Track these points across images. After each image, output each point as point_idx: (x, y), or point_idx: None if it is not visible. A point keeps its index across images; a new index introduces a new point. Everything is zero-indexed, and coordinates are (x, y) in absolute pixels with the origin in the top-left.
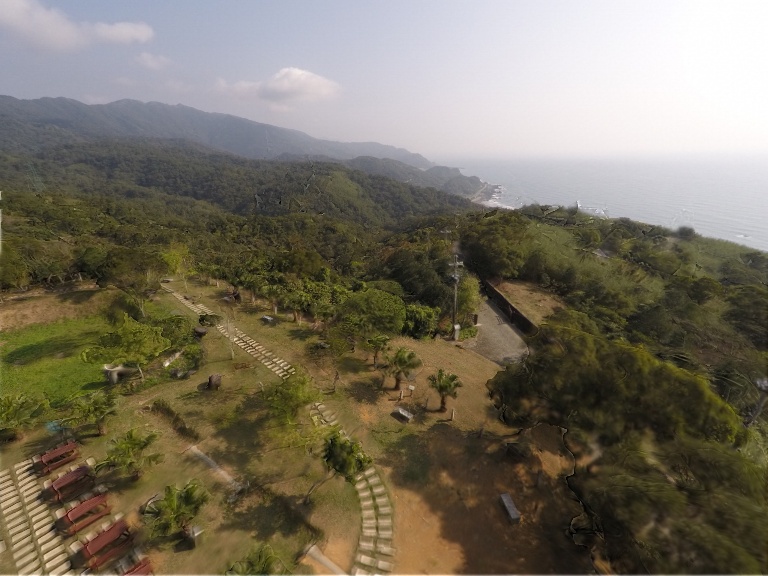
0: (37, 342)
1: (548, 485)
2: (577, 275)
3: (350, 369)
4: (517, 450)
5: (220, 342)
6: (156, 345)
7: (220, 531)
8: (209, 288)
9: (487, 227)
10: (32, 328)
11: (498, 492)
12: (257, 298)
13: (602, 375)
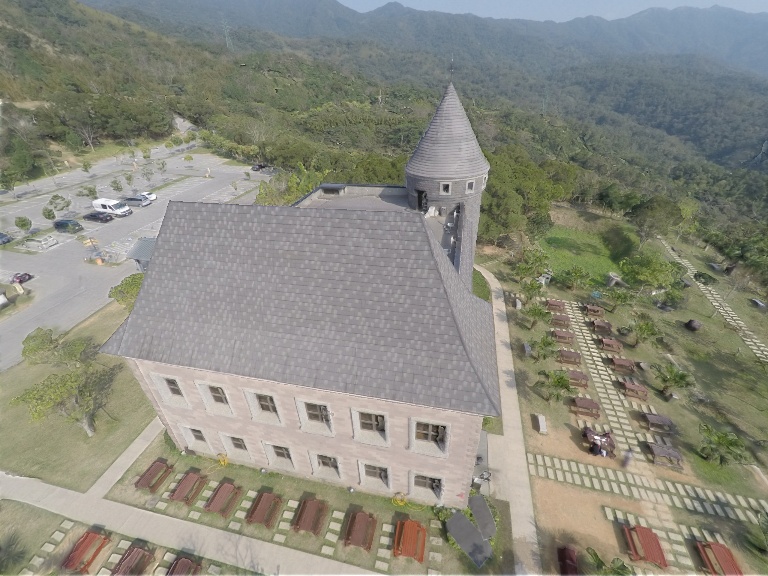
0: (561, 237)
1: None
2: None
3: None
4: None
5: (700, 299)
6: (667, 278)
7: (683, 407)
8: (696, 248)
9: None
10: (559, 227)
11: None
12: (752, 279)
13: None
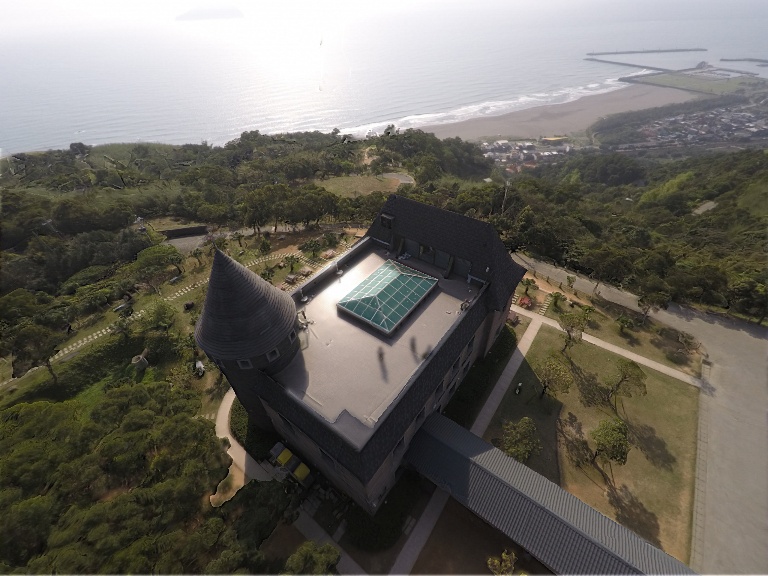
0: None
1: None
2: (154, 200)
3: (200, 270)
4: (267, 232)
5: None
6: None
7: None
8: (2, 368)
9: (35, 209)
10: None
11: None
12: None
13: (267, 196)
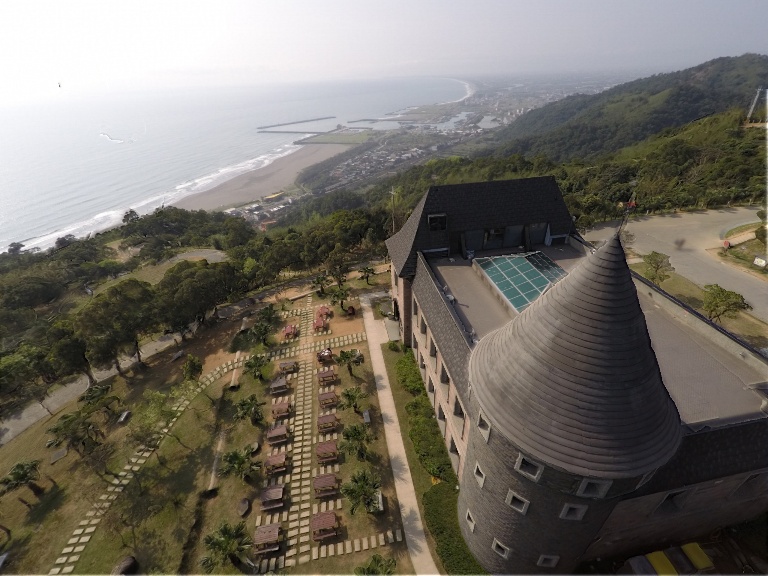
0: None
1: None
2: None
3: (57, 499)
4: (140, 364)
5: None
6: None
7: None
8: None
9: None
10: None
11: (169, 364)
12: None
13: None
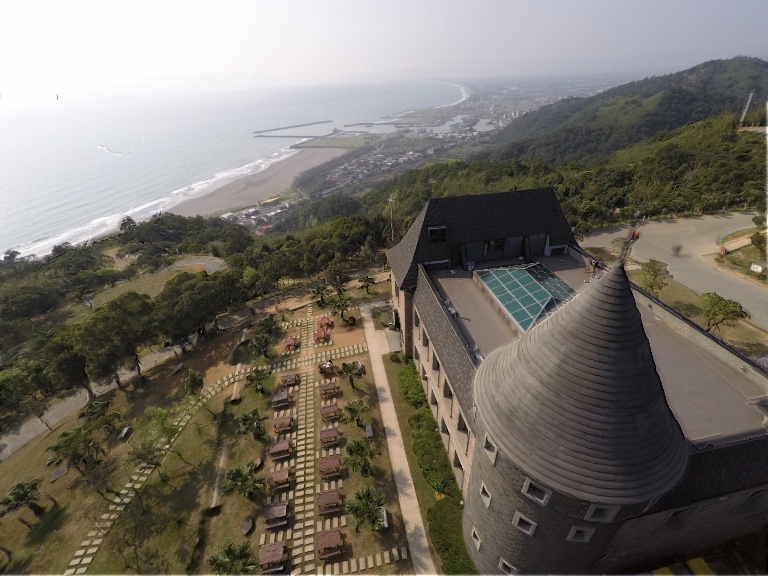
0: None
1: (154, 371)
2: None
3: (58, 519)
4: (140, 377)
5: None
6: None
7: None
8: None
9: None
10: None
11: (169, 378)
12: None
13: None
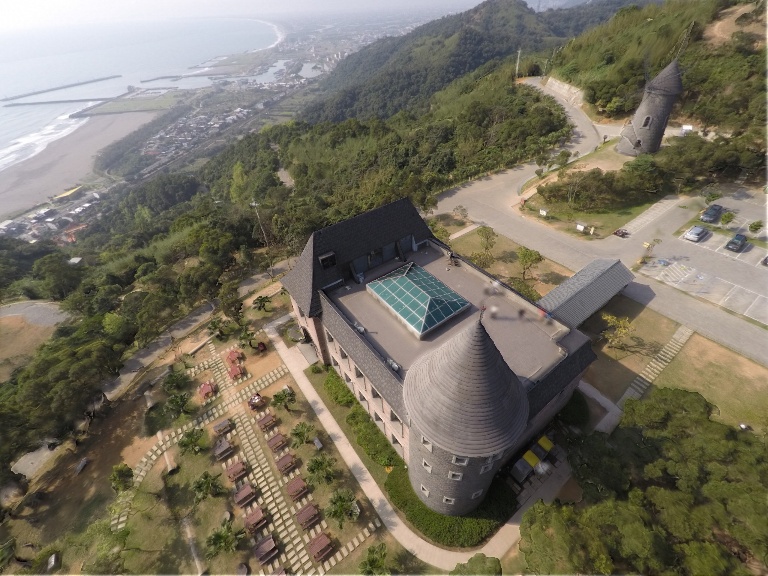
0: None
1: None
2: None
3: None
4: (37, 495)
5: None
6: None
7: None
8: None
9: None
10: None
11: (75, 479)
12: None
13: None
